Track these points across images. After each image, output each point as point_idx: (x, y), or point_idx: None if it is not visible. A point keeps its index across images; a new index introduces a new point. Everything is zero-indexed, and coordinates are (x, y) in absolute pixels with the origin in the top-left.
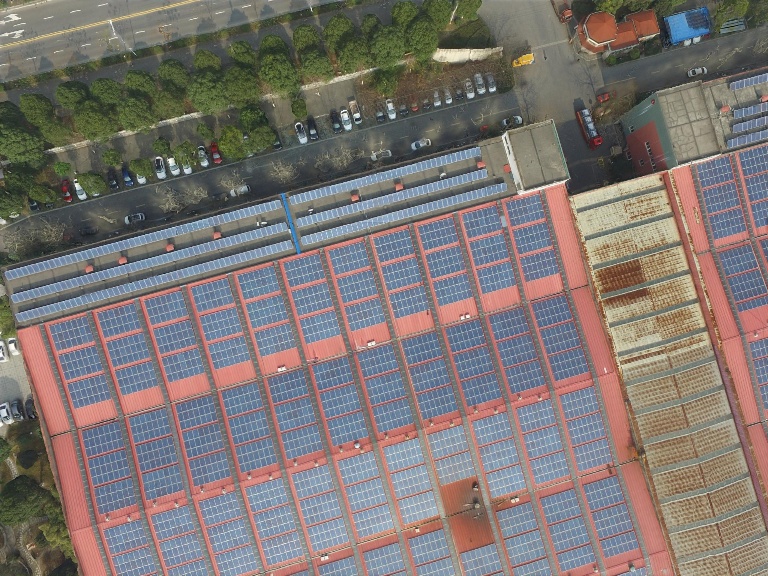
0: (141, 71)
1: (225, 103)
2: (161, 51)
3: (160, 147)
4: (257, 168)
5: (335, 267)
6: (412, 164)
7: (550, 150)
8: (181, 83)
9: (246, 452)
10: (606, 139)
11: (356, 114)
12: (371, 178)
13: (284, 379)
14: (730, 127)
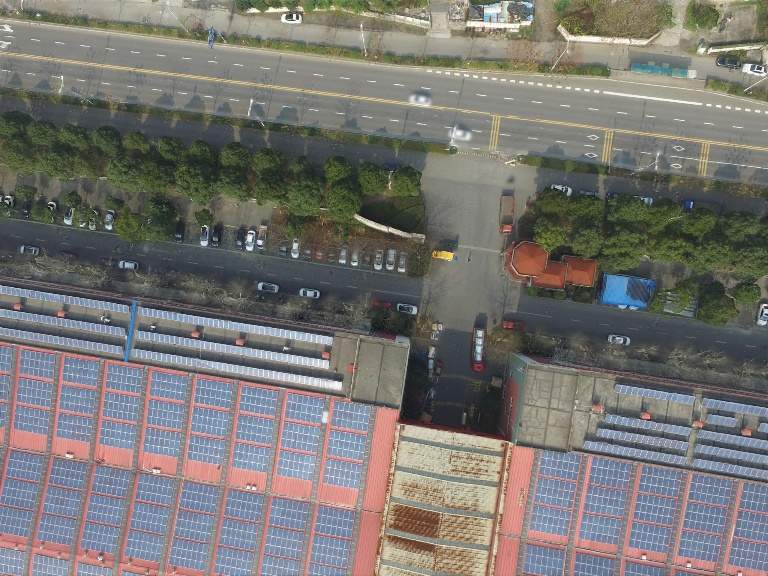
0: (77, 128)
1: (136, 187)
2: (115, 109)
3: (67, 202)
4: (153, 250)
5: (152, 388)
6: (261, 326)
7: (394, 373)
8: (109, 151)
9: (6, 515)
10: (494, 365)
11: (259, 240)
12: (219, 322)
13: (68, 466)
14: (597, 427)
